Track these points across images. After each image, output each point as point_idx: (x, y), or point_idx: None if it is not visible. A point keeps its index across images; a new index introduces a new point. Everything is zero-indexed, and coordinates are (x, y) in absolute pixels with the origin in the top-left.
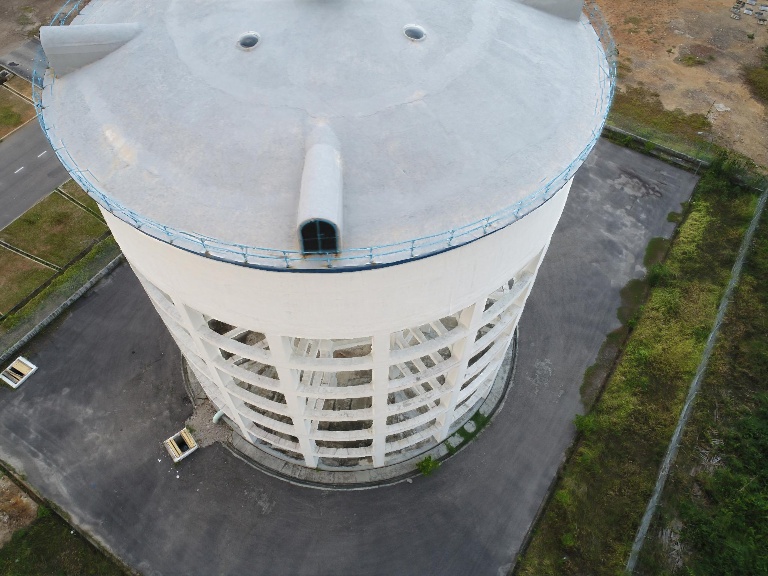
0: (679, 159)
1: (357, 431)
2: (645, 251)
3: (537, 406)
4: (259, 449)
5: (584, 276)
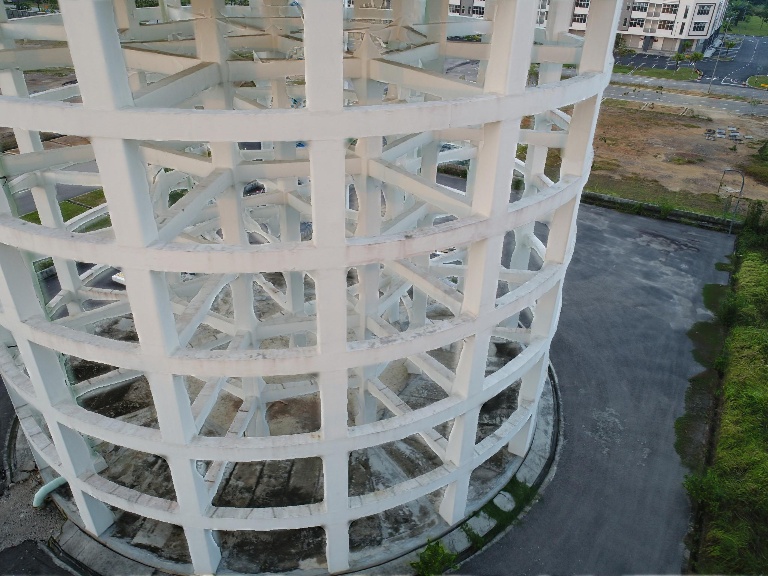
0: (704, 222)
1: (289, 436)
2: (702, 296)
3: (612, 471)
4: (107, 548)
5: (631, 319)
